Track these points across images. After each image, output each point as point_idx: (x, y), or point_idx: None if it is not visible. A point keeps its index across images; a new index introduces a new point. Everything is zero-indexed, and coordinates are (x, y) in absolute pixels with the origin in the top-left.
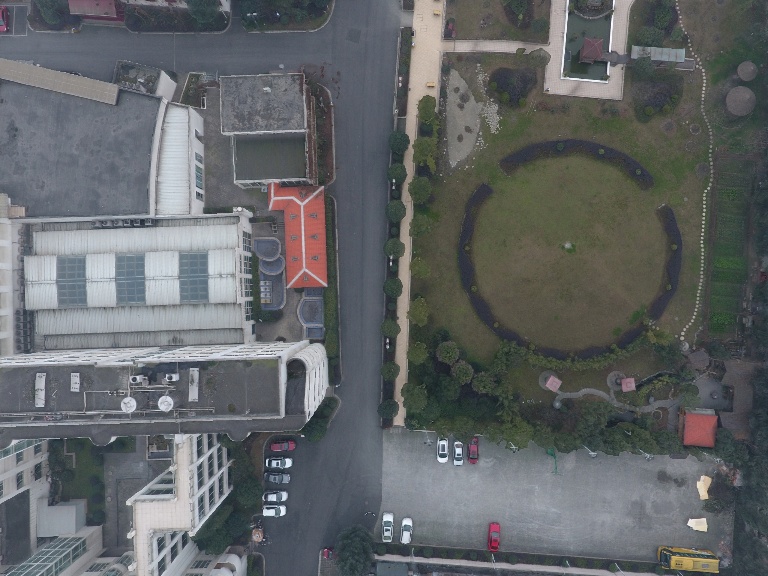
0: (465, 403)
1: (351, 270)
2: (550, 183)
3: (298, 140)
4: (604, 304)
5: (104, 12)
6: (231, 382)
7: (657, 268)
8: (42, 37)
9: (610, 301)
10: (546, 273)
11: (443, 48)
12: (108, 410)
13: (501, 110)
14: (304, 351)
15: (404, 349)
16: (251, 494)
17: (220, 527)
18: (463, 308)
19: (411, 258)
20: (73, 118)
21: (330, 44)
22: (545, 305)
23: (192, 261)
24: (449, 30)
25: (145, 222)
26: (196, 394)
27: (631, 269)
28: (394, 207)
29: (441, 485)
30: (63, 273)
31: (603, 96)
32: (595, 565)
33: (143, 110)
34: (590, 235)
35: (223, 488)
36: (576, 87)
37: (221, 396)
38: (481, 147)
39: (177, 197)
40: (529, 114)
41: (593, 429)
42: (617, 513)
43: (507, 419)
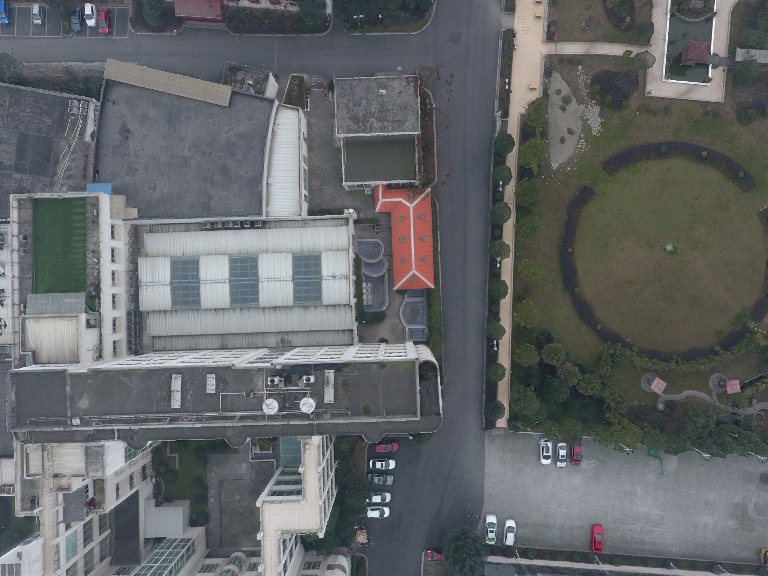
0: (572, 405)
1: (453, 272)
2: (652, 185)
3: (407, 142)
4: (706, 306)
5: (209, 14)
6: (366, 384)
7: (759, 270)
8: (143, 39)
9: (712, 303)
10: (648, 275)
11: (544, 50)
12: (244, 411)
13: (603, 112)
14: (425, 353)
15: (506, 351)
16: (360, 495)
17: (333, 528)
18: (565, 310)
19: (513, 260)
20: (185, 120)
21: (431, 46)
22: (647, 307)
23: (305, 263)
24: (552, 32)
25: (255, 224)
26: (332, 396)
27: (733, 271)
28: (501, 209)
29: (543, 487)
30: (177, 274)
31: (704, 98)
32: (698, 567)
33: (255, 112)
34: (692, 237)
35: (332, 489)
36: (677, 89)
37: (356, 398)
38: (583, 149)
39: (287, 199)
40: (631, 116)
41: (701, 431)
42: (719, 515)
43: (614, 421)
